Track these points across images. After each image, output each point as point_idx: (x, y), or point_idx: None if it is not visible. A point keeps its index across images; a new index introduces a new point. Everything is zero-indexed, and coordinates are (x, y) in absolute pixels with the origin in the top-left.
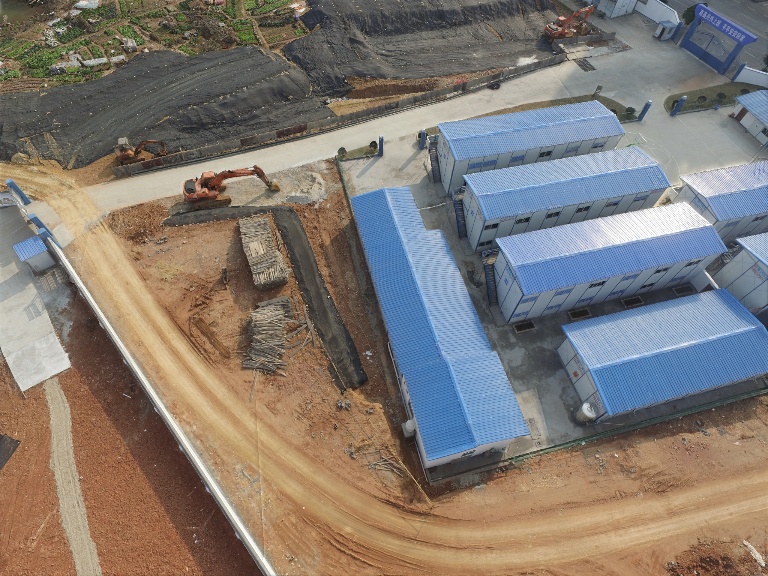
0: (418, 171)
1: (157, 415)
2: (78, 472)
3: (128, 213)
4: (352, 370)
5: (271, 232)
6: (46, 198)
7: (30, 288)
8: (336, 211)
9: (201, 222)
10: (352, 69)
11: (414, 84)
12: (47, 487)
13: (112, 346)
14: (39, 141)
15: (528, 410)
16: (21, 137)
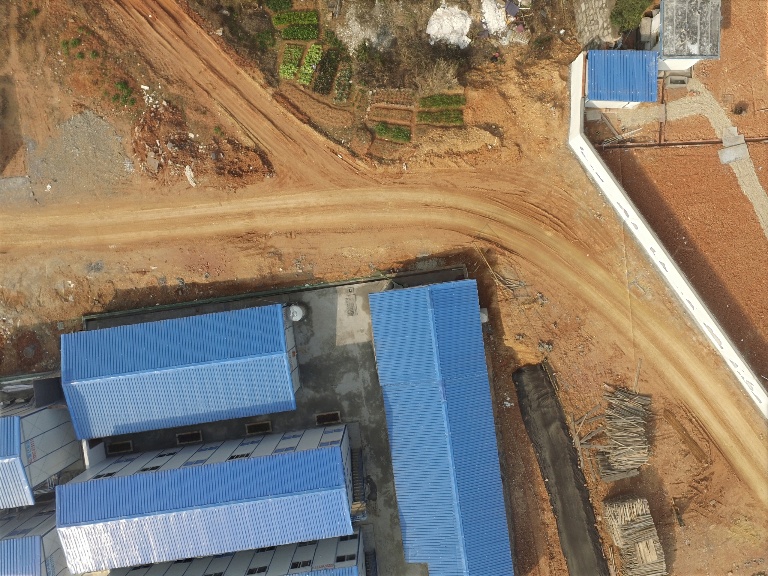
0: None
1: None
2: None
3: None
4: (528, 386)
5: None
6: None
7: None
8: None
9: None
10: None
11: None
12: None
13: None
14: None
15: (351, 324)
16: None
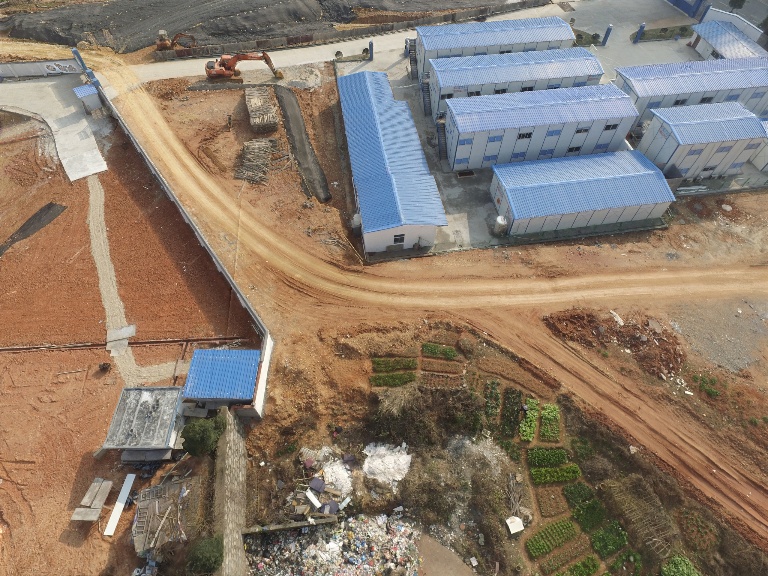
0: (400, 71)
1: (167, 200)
2: (106, 226)
3: (161, 83)
4: (321, 192)
5: (270, 98)
6: (100, 70)
7: (83, 121)
8: (327, 94)
9: (217, 89)
10: (358, 1)
11: (411, 16)
12: (83, 233)
13: (139, 159)
14: (99, 34)
15: (457, 225)
16: (85, 31)
